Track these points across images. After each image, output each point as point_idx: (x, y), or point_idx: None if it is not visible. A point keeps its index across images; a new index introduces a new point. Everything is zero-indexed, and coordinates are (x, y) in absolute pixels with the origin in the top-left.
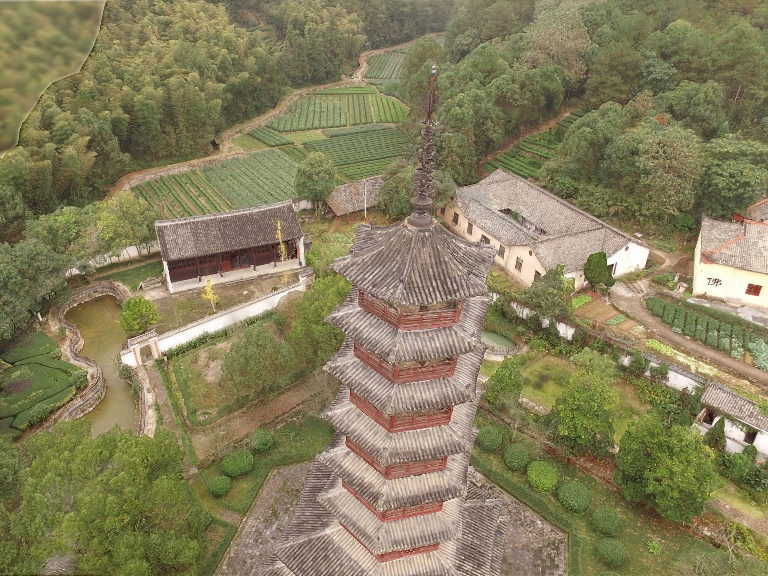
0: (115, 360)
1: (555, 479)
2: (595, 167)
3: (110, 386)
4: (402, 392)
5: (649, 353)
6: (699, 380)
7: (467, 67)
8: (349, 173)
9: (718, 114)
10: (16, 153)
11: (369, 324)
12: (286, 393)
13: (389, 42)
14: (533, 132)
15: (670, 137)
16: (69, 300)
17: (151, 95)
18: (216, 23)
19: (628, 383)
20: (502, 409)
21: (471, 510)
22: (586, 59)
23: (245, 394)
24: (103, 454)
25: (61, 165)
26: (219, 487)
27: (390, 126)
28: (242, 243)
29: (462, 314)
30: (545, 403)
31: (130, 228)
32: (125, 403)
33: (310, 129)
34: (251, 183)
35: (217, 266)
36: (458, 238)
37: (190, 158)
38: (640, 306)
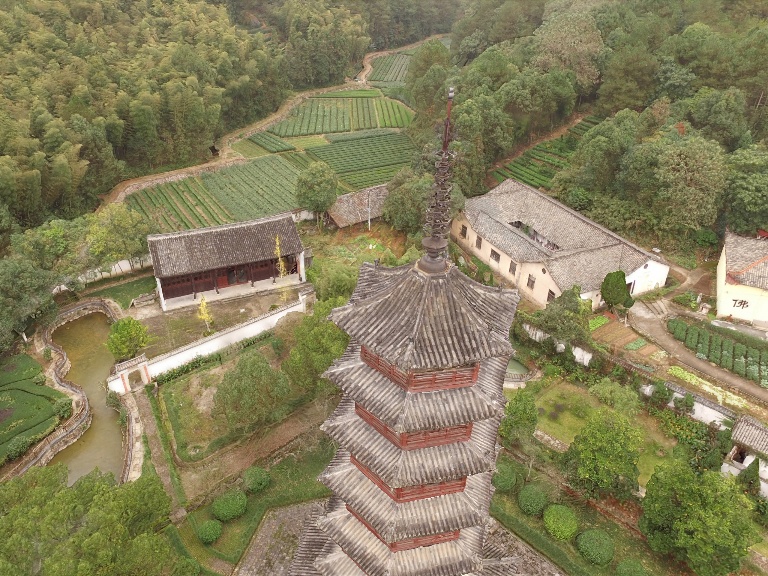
0: (103, 385)
1: (574, 526)
2: (610, 178)
3: (96, 414)
4: (411, 460)
5: (672, 382)
6: (728, 414)
7: (475, 71)
8: (352, 181)
9: (740, 122)
10: (3, 163)
11: (373, 382)
12: (283, 424)
13: (394, 44)
14: (544, 139)
15: (692, 148)
16: (57, 318)
17: (147, 100)
18: (216, 25)
19: (650, 415)
20: (515, 444)
21: (485, 571)
22: (599, 63)
23: (239, 425)
24: (77, 509)
25: (51, 174)
26: (209, 533)
27: (395, 131)
28: (239, 258)
29: (480, 369)
30: (561, 437)
31: (122, 242)
32: (112, 433)
33: (312, 134)
34: (251, 191)
35: (213, 282)
36: (476, 283)
37: (188, 165)
38: (661, 329)
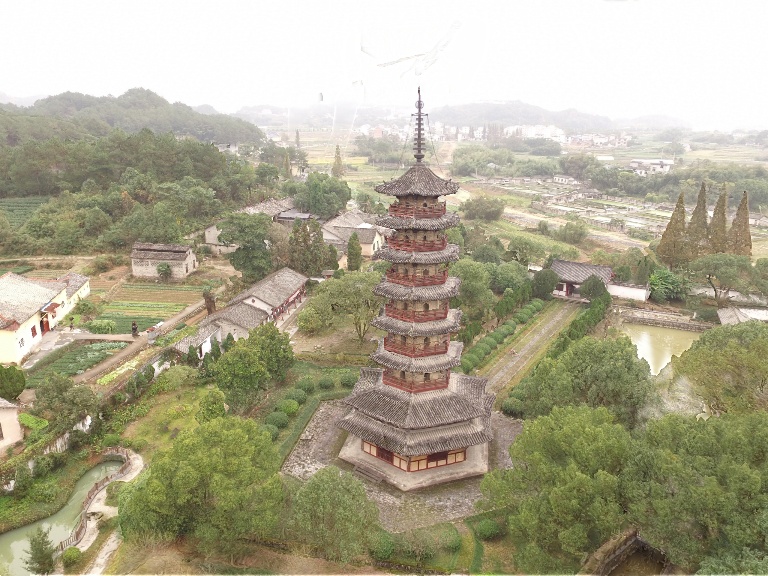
0: None
1: None
2: None
3: None
4: None
5: None
6: None
7: None
8: None
9: None
10: None
11: None
12: (296, 575)
13: None
14: None
15: None
16: None
17: None
18: None
19: None
20: None
21: None
22: None
23: None
24: None
25: None
26: (455, 533)
27: None
28: None
29: None
30: None
31: None
32: None
33: None
34: None
35: None
36: None
37: None
38: None
